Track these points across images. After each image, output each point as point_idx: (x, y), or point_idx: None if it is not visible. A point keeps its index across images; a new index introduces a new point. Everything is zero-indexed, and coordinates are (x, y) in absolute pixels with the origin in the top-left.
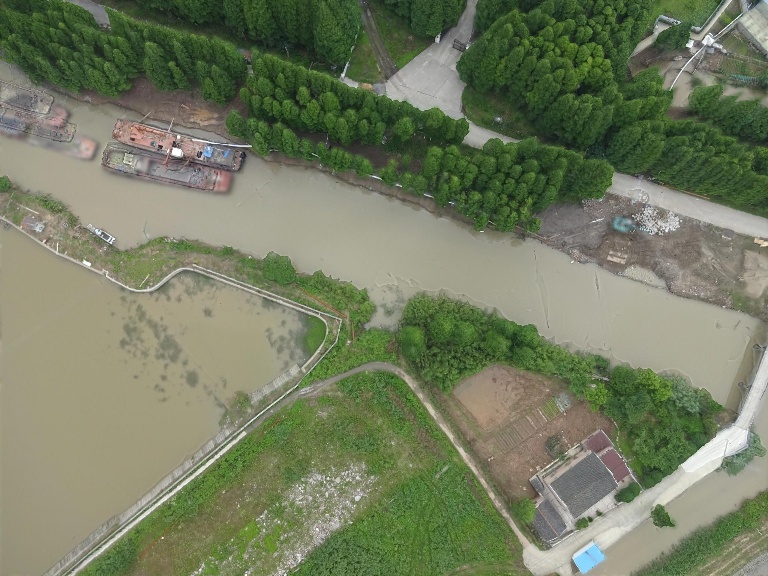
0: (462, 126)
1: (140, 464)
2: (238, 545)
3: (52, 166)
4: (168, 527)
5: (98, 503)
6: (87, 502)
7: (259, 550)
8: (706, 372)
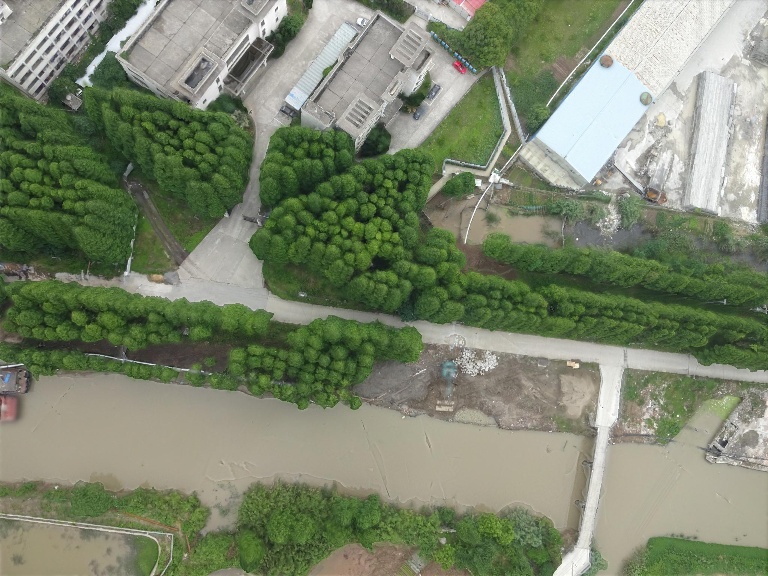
0: (259, 329)
1: None
2: None
3: None
4: None
5: None
6: None
7: None
8: (547, 488)
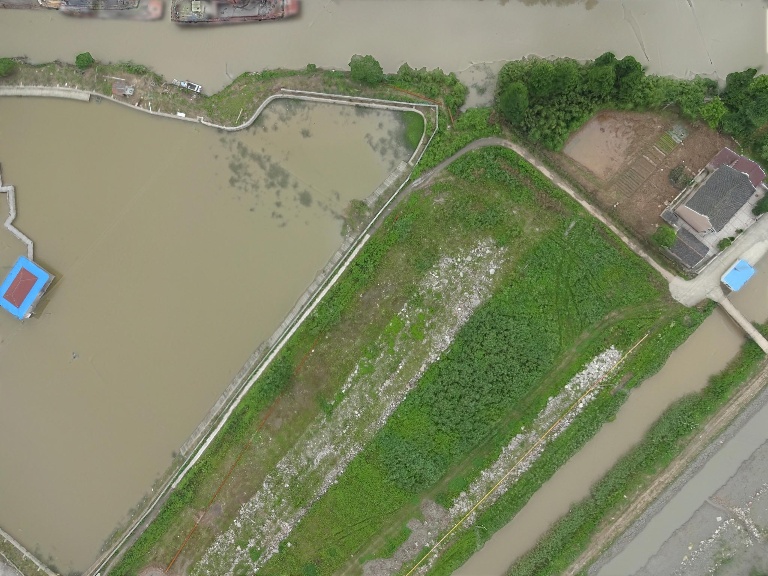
0: None
1: (275, 292)
2: (386, 341)
3: (126, 35)
4: (316, 339)
5: (244, 336)
6: (234, 337)
7: (408, 341)
8: None
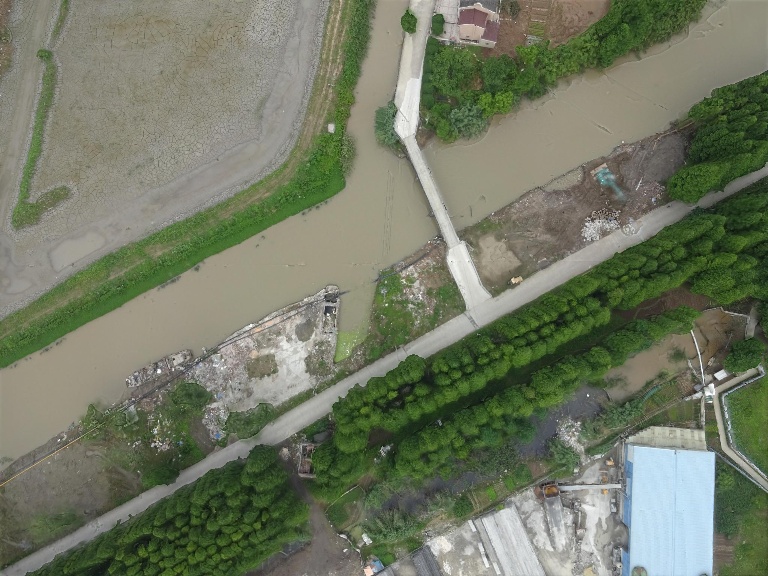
0: None
1: None
2: None
3: None
4: None
5: None
6: None
7: None
8: (446, 177)
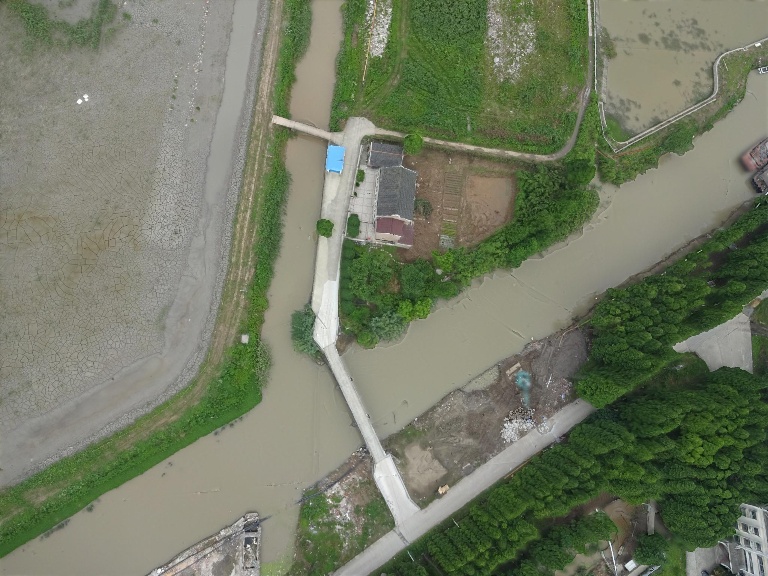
0: (718, 318)
1: None
2: None
3: None
4: None
5: None
6: None
7: None
8: (365, 373)
